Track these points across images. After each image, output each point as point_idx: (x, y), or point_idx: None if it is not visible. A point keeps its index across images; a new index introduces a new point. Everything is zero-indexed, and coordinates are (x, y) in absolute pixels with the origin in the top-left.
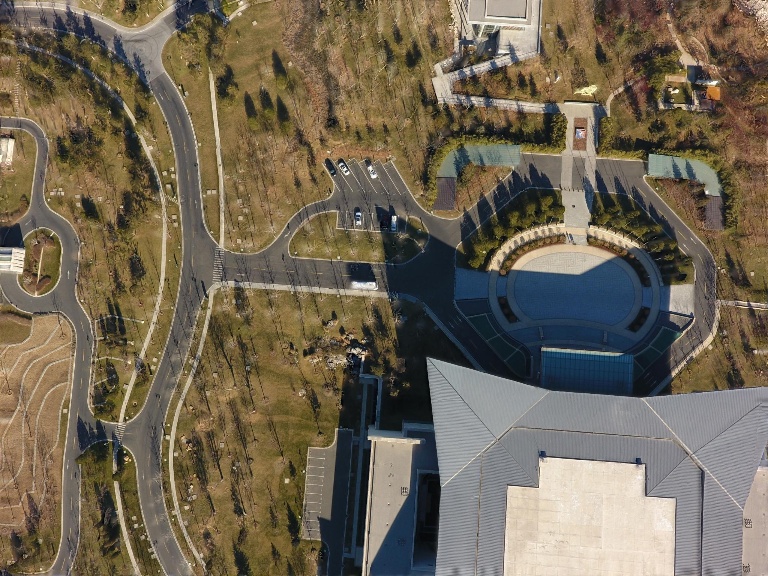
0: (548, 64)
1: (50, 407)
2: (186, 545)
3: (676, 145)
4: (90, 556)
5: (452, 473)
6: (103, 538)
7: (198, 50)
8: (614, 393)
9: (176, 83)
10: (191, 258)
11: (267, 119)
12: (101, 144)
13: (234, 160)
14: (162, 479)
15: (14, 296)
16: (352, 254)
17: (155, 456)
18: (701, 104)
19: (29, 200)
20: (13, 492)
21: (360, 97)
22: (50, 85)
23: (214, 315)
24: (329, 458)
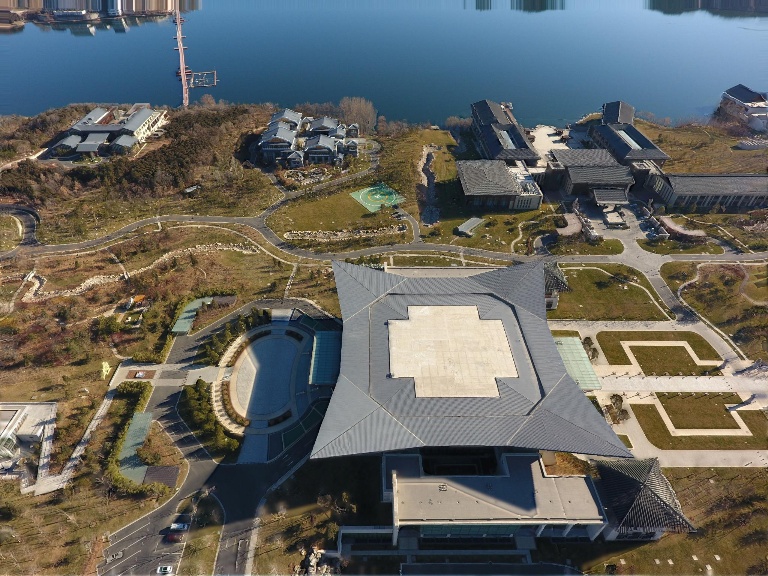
0: (69, 395)
1: None
2: None
3: None
4: None
5: (413, 438)
6: None
7: None
8: None
9: None
10: None
11: None
12: None
13: None
14: None
15: None
16: (204, 574)
17: None
18: (145, 306)
19: None
20: None
21: None
22: None
23: None
24: None
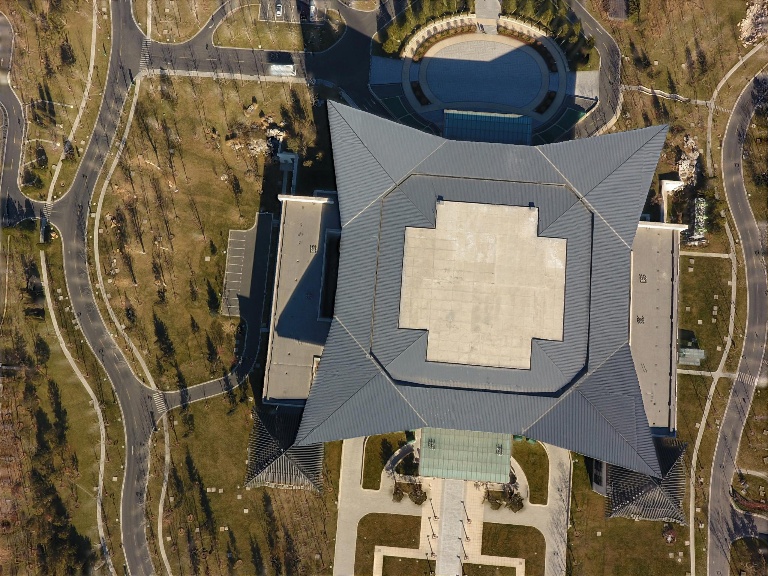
0: None
1: None
2: (109, 317)
3: None
4: (15, 324)
5: (352, 215)
6: (26, 300)
7: None
8: None
9: None
10: (119, 48)
11: None
12: None
13: None
14: (87, 254)
15: None
16: (272, 42)
17: (81, 233)
18: None
19: None
20: None
21: None
22: None
23: (140, 101)
24: (249, 240)
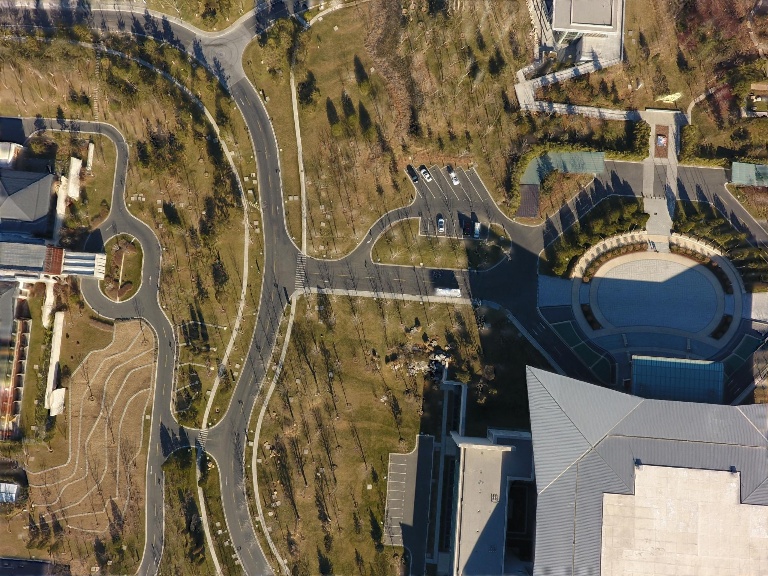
0: (632, 71)
1: (133, 413)
2: (270, 551)
3: (758, 153)
4: (175, 562)
5: (548, 481)
6: (190, 544)
7: (281, 55)
8: (705, 401)
9: (257, 88)
10: (273, 264)
11: (350, 125)
12: (182, 149)
13: (316, 166)
14: (245, 485)
15: (96, 302)
16: (435, 261)
17: (238, 462)
18: None
19: (109, 205)
20: (97, 498)
21: (443, 103)
22: (130, 89)
23: (297, 321)
24: (410, 464)
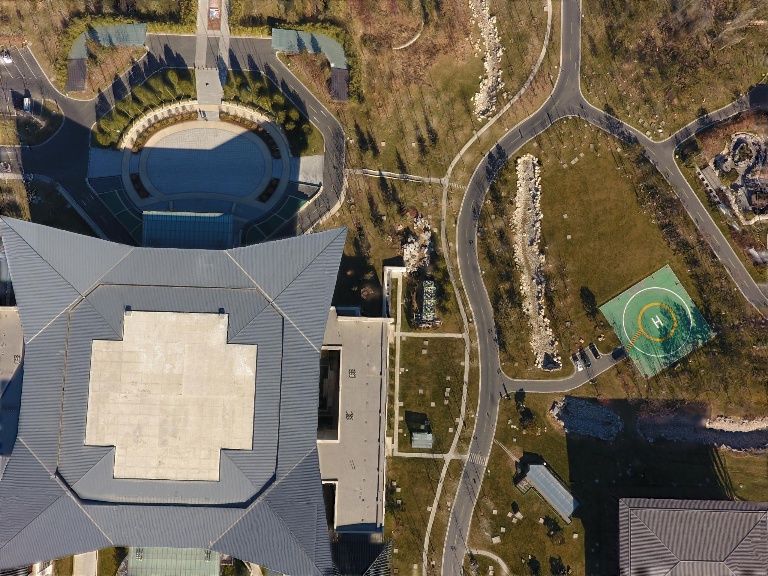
0: None
1: None
2: None
3: None
4: None
5: (36, 330)
6: None
7: None
8: None
9: None
10: None
11: None
12: None
13: None
14: None
15: None
16: None
17: None
18: None
19: None
20: None
21: None
22: None
23: None
24: None
